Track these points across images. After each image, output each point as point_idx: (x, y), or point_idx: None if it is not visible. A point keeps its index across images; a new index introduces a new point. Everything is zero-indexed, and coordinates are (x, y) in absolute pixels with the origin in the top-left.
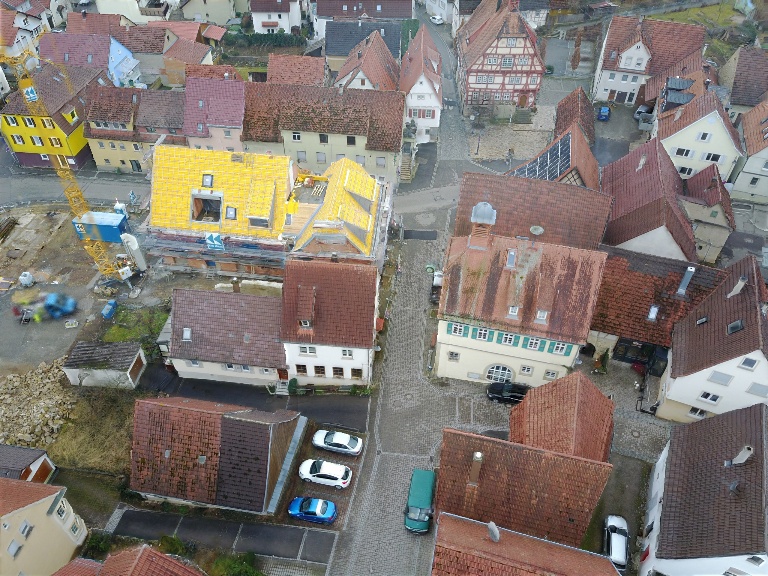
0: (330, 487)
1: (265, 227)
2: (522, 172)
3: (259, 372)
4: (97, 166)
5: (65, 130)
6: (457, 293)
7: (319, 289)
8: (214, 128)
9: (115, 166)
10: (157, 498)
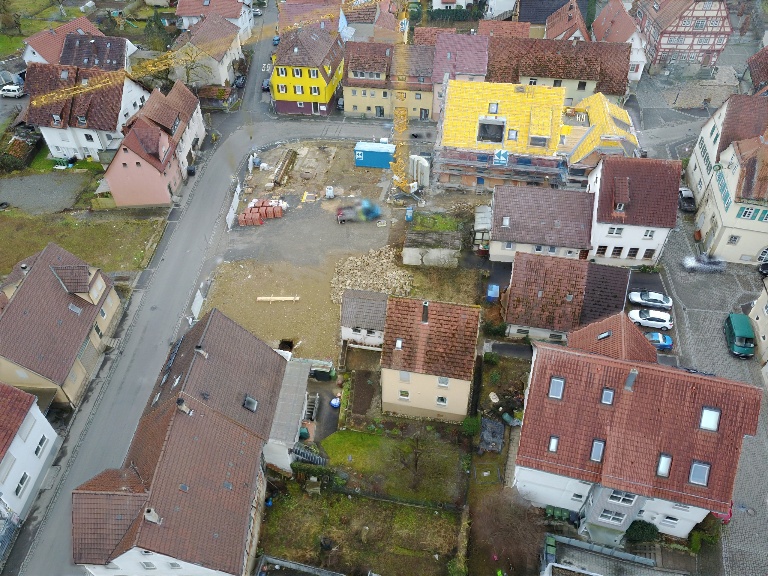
0: (656, 329)
1: (542, 146)
2: None
3: (563, 254)
4: (345, 112)
5: (326, 80)
6: (752, 181)
7: (632, 179)
8: (461, 76)
9: (361, 112)
10: (518, 334)
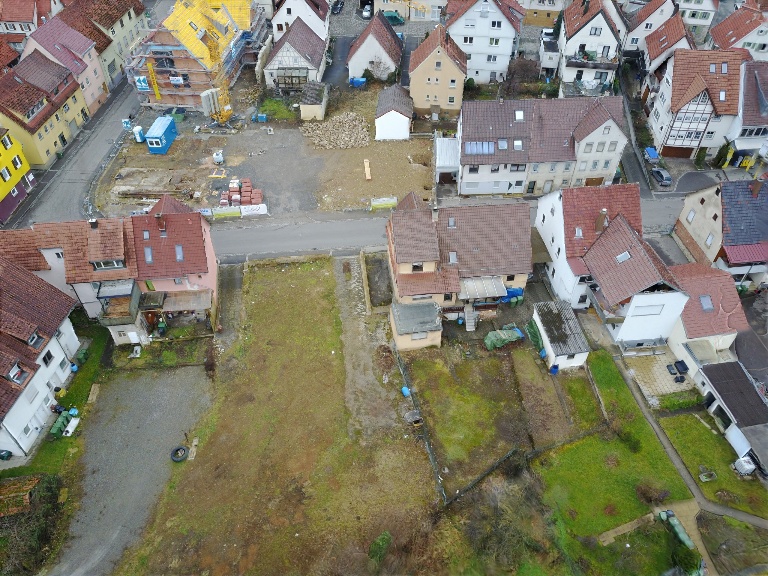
0: None
1: None
2: None
3: None
4: (45, 165)
5: None
6: None
7: None
8: (85, 55)
9: (54, 153)
10: None
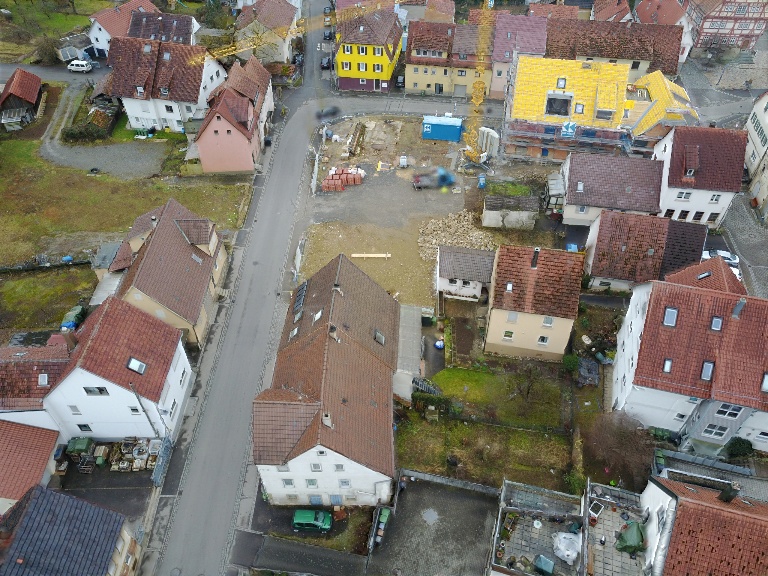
0: None
1: (607, 119)
2: None
3: None
4: (405, 89)
5: (389, 57)
6: None
7: (701, 147)
8: (521, 55)
9: (421, 89)
10: (600, 287)
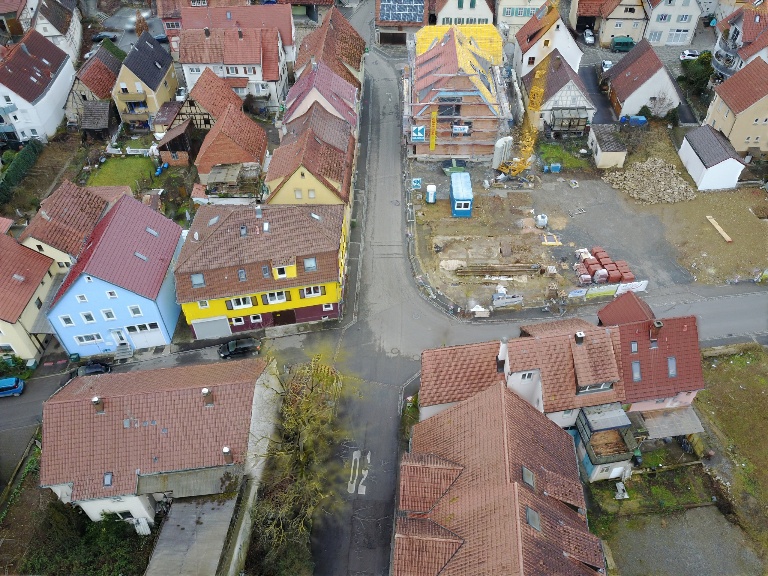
0: None
1: None
2: (388, 6)
3: None
4: None
5: None
6: None
7: None
8: None
9: (349, 222)
10: None
